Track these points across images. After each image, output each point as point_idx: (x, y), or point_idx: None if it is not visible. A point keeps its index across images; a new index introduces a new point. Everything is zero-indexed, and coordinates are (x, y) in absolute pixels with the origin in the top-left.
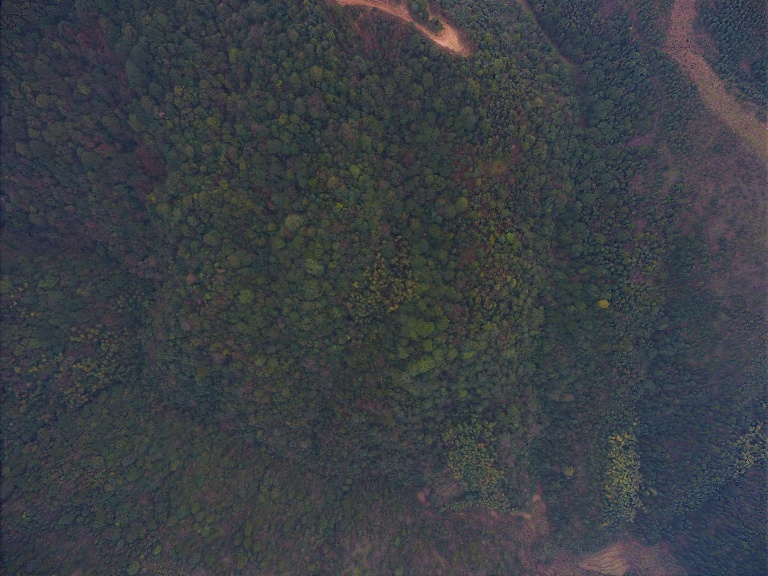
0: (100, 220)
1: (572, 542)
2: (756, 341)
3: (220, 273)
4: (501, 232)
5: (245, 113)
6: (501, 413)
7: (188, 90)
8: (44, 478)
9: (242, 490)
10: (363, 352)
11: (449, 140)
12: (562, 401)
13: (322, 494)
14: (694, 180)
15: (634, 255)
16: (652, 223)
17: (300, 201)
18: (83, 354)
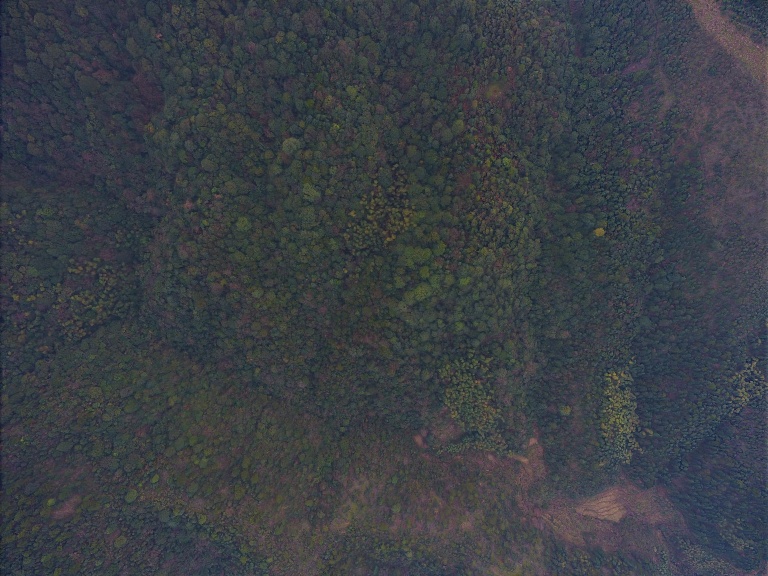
0: (98, 152)
1: (569, 484)
2: (751, 270)
3: (217, 199)
4: (497, 158)
5: (242, 34)
6: (498, 347)
7: (185, 9)
8: (42, 405)
9: (240, 426)
10: (360, 287)
11: (445, 61)
12: (558, 338)
13: (320, 434)
14: (689, 104)
15: (630, 181)
16: (647, 149)
17: (297, 124)
18: (81, 287)
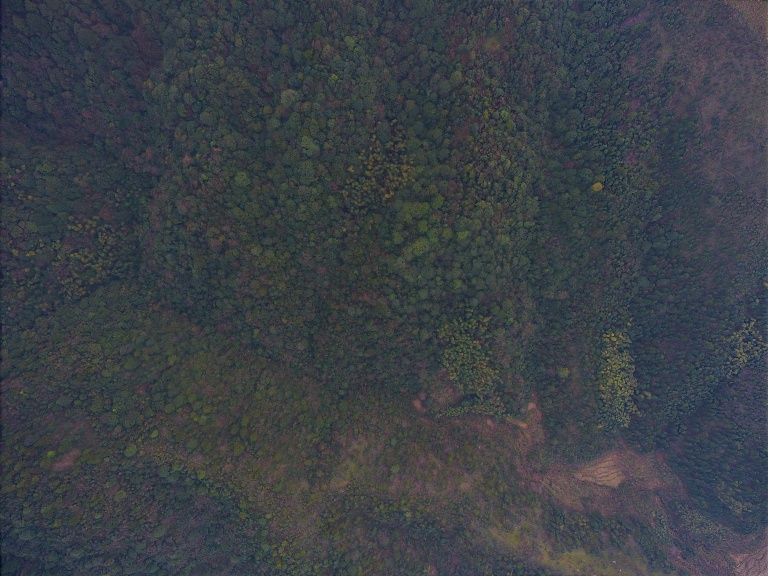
0: (97, 110)
1: (567, 448)
2: (749, 226)
3: (216, 153)
4: (495, 111)
5: None
6: (496, 306)
7: None
8: (42, 359)
9: (239, 386)
10: (359, 246)
11: (443, 11)
12: (557, 299)
13: (319, 397)
14: (687, 57)
15: (627, 135)
16: (645, 102)
17: (295, 75)
18: (80, 244)
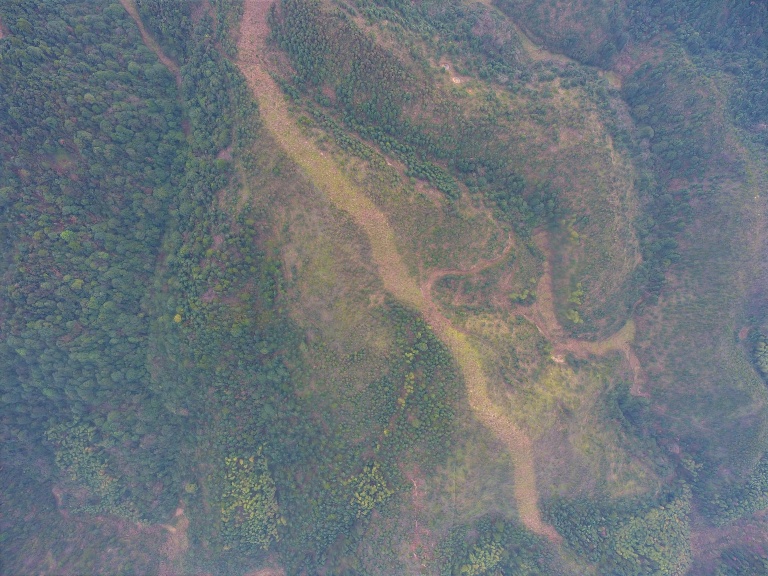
0: None
1: (204, 562)
2: (338, 378)
3: None
4: (64, 229)
5: None
6: (97, 418)
7: None
8: None
9: None
10: None
11: None
12: (179, 415)
13: None
14: (262, 202)
15: None
16: (223, 241)
17: None
18: None
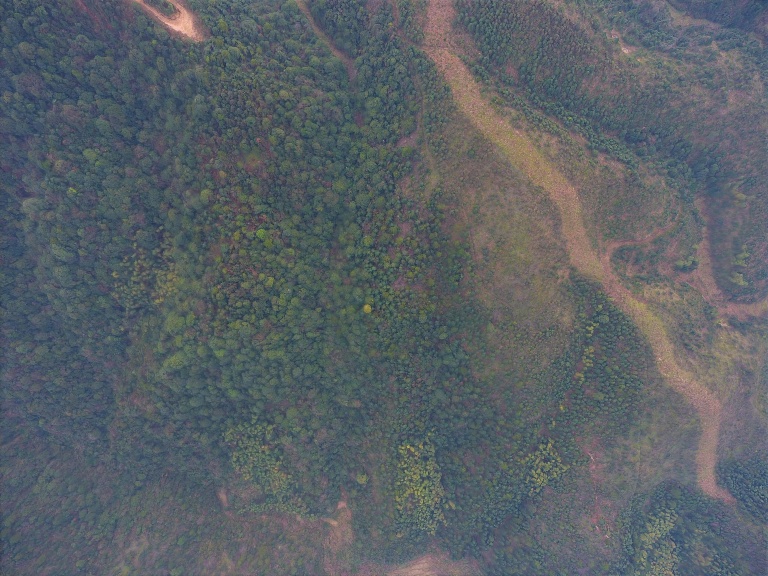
0: None
1: (372, 552)
2: (527, 356)
3: None
4: (255, 228)
5: None
6: (278, 415)
7: None
8: None
9: (14, 479)
10: (140, 345)
11: None
12: (351, 407)
13: (112, 488)
14: (453, 185)
15: (394, 260)
16: (413, 228)
17: (38, 184)
18: None
